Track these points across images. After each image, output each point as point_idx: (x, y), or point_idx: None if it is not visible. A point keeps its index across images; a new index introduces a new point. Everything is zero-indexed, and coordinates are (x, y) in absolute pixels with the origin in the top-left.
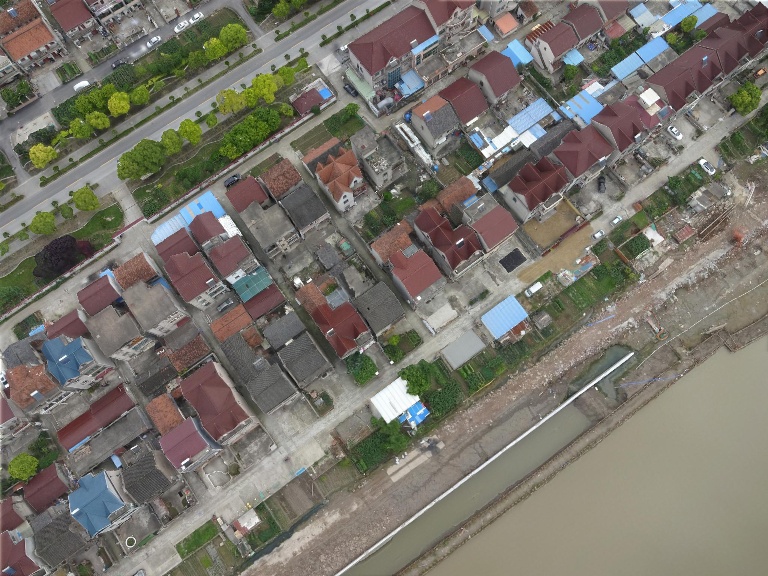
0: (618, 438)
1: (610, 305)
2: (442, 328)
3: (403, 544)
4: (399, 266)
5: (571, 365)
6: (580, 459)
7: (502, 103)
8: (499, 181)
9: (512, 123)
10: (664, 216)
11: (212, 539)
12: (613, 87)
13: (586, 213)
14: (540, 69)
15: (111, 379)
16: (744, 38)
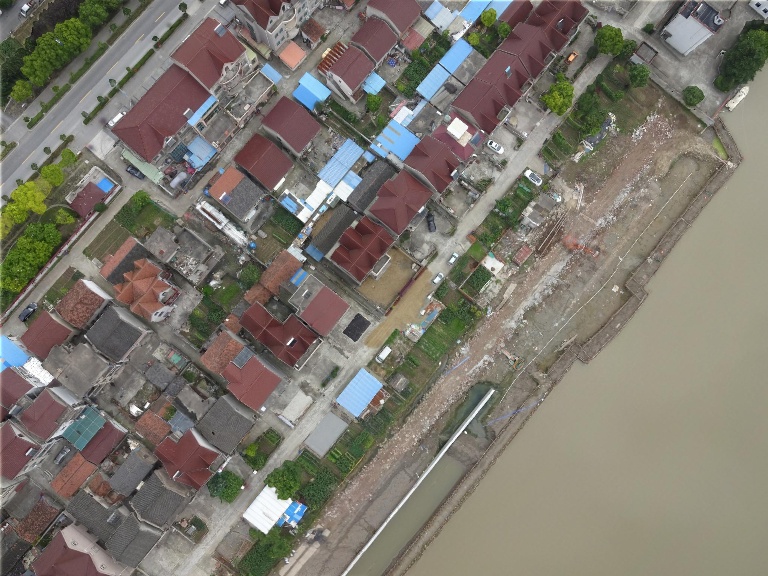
0: (494, 477)
1: (463, 347)
2: (300, 419)
3: None
4: (234, 381)
5: (437, 418)
6: (462, 507)
7: (308, 152)
8: (323, 248)
9: (323, 176)
10: (500, 240)
11: None
12: (422, 110)
13: (421, 258)
14: (342, 101)
15: None
16: (545, 33)
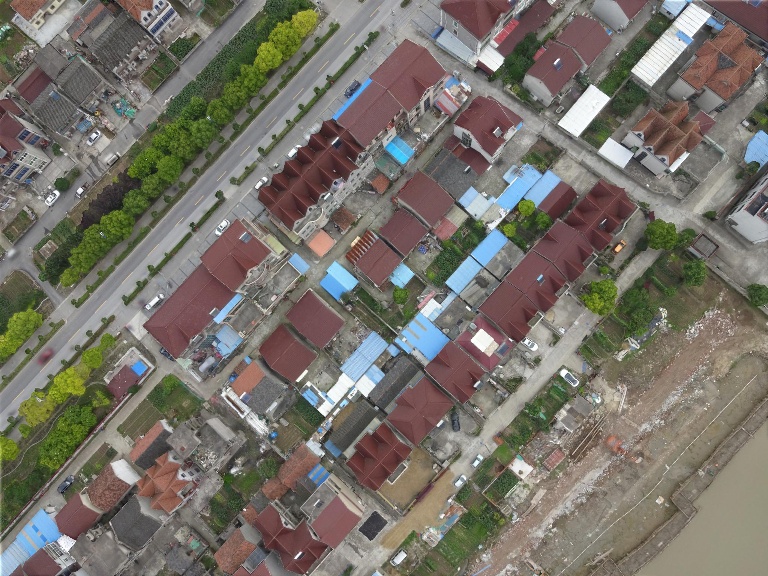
0: None
1: (485, 553)
2: None
3: None
4: None
5: None
6: None
7: (333, 341)
8: (341, 446)
9: (346, 369)
10: None
11: None
12: (451, 304)
13: (443, 458)
14: (370, 288)
15: None
16: (585, 235)
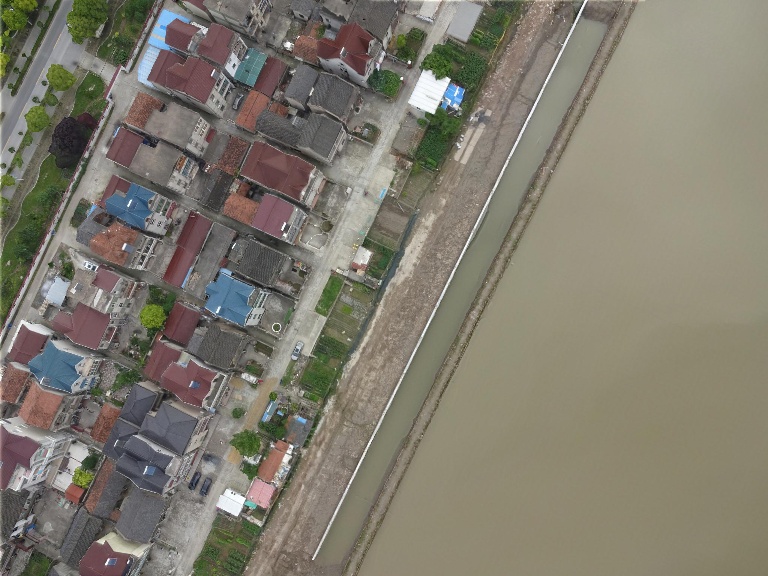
0: (637, 22)
1: None
2: (436, 13)
3: (499, 210)
4: None
5: None
6: (613, 58)
7: None
8: None
9: None
10: None
11: (341, 290)
12: None
13: None
14: None
15: (179, 216)
16: None
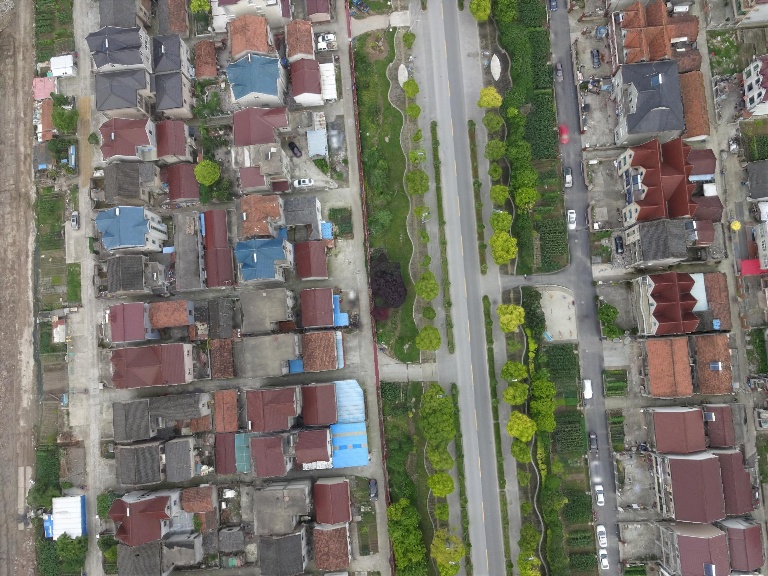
0: None
1: None
2: None
3: None
4: None
5: None
6: None
7: None
8: None
9: None
10: None
11: None
12: None
13: None
14: None
15: None
16: None
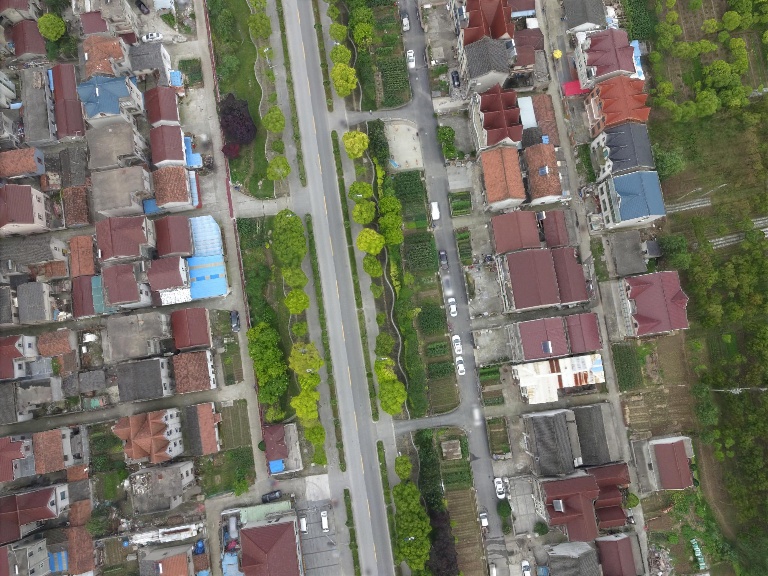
0: None
1: None
2: None
3: None
4: (7, 447)
5: None
6: None
7: None
8: None
9: None
10: None
11: None
12: None
13: None
14: None
15: None
16: None
